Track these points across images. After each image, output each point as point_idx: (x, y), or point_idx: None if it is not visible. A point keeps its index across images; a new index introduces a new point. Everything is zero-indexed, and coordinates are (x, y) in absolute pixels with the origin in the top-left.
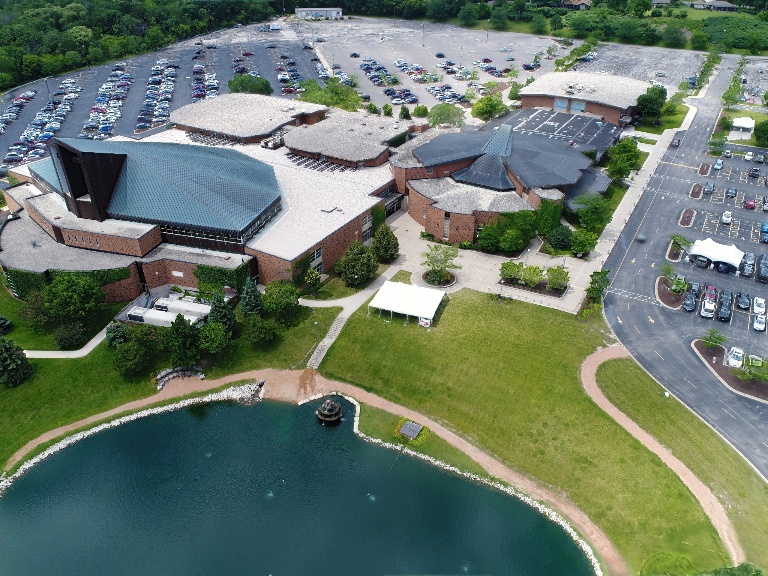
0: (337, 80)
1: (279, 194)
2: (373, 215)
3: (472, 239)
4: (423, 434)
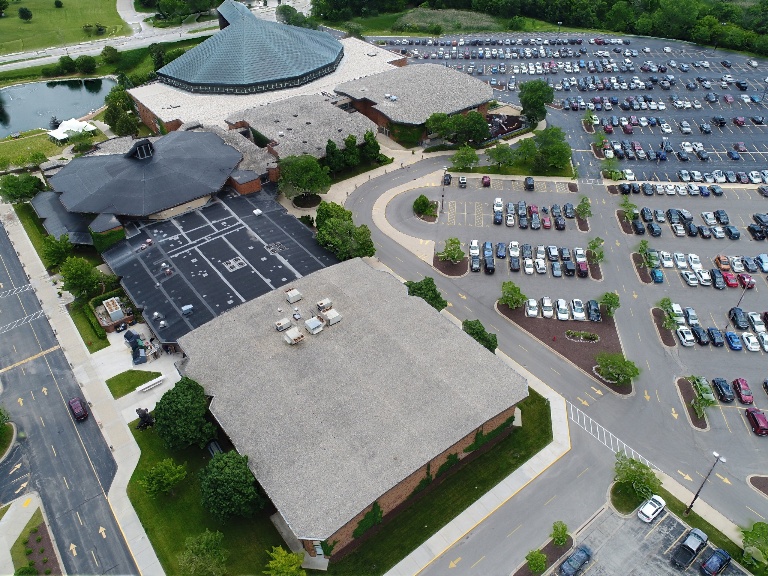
0: (555, 146)
1: (191, 82)
2: None
3: None
4: (10, 137)
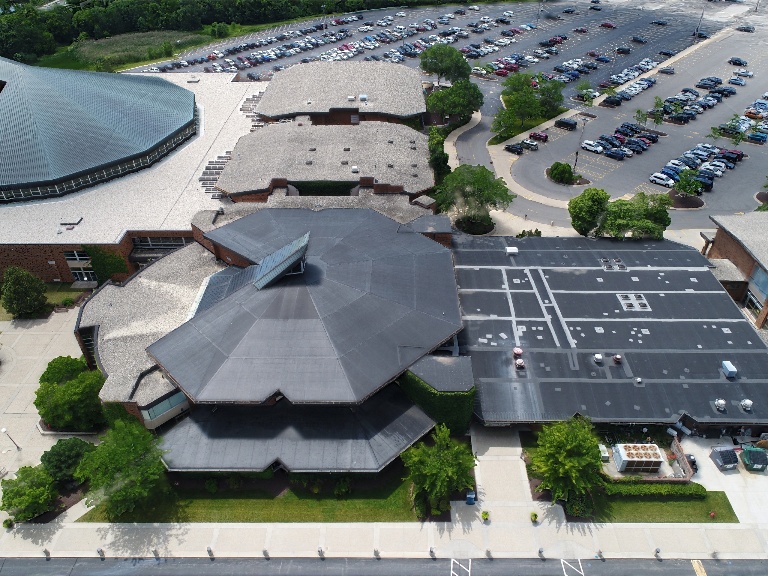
0: (552, 85)
1: (53, 178)
2: (91, 255)
3: (88, 363)
4: None
